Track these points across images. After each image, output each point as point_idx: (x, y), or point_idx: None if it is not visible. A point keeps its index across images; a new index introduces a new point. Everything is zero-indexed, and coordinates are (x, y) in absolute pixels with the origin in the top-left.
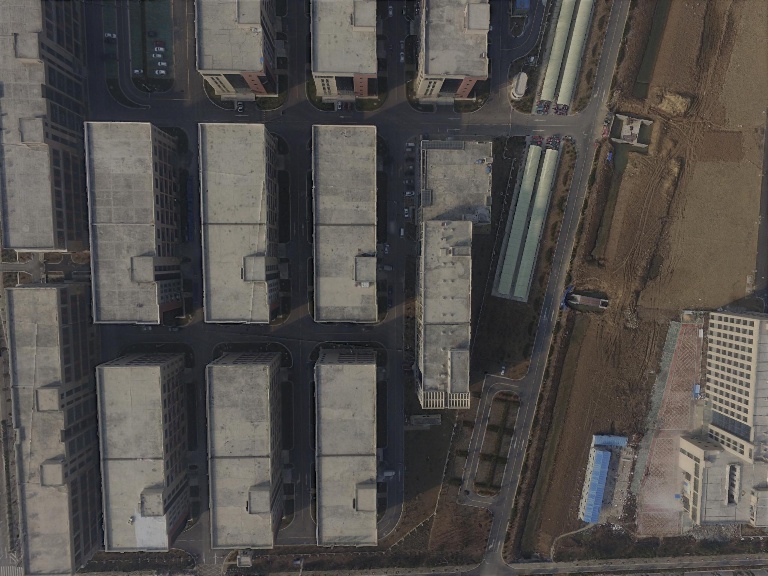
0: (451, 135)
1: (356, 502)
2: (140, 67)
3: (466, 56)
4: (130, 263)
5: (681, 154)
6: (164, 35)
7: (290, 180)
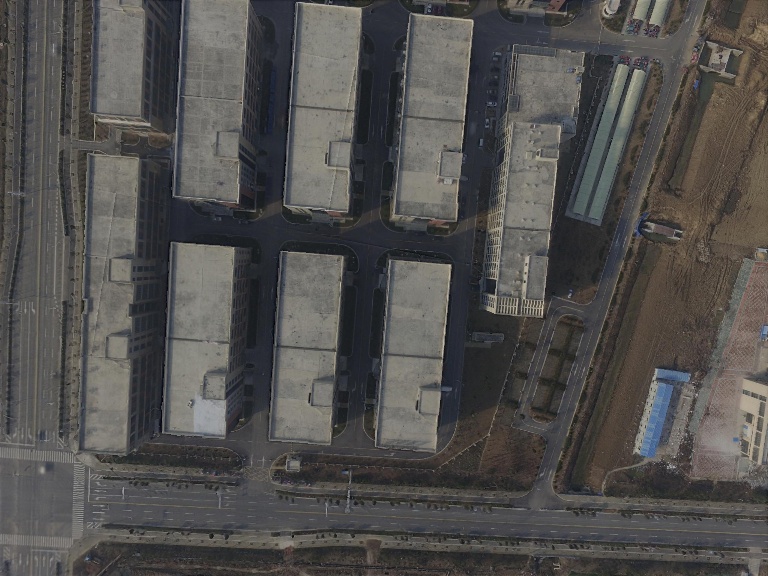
0: None
1: (419, 404)
2: None
3: None
4: (216, 137)
5: None
6: None
7: (373, 81)
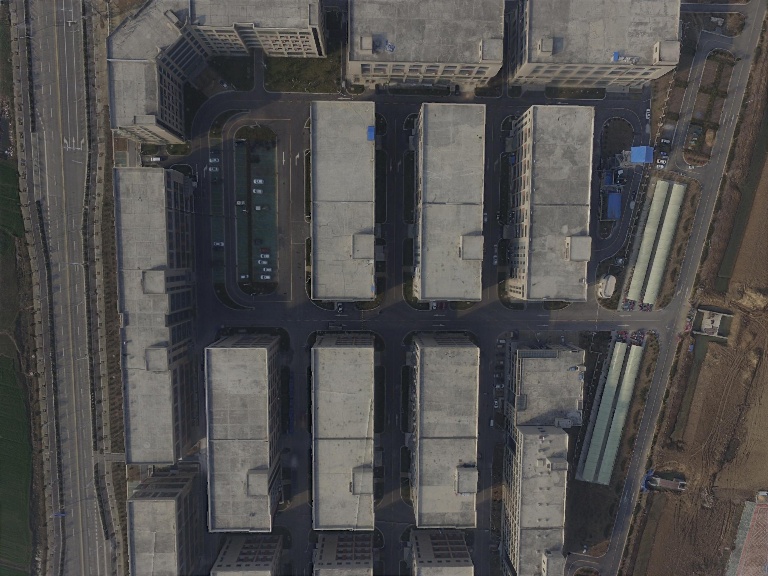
0: (540, 331)
1: None
2: (246, 272)
3: (566, 281)
4: (246, 479)
5: (760, 345)
6: (269, 242)
7: (385, 374)
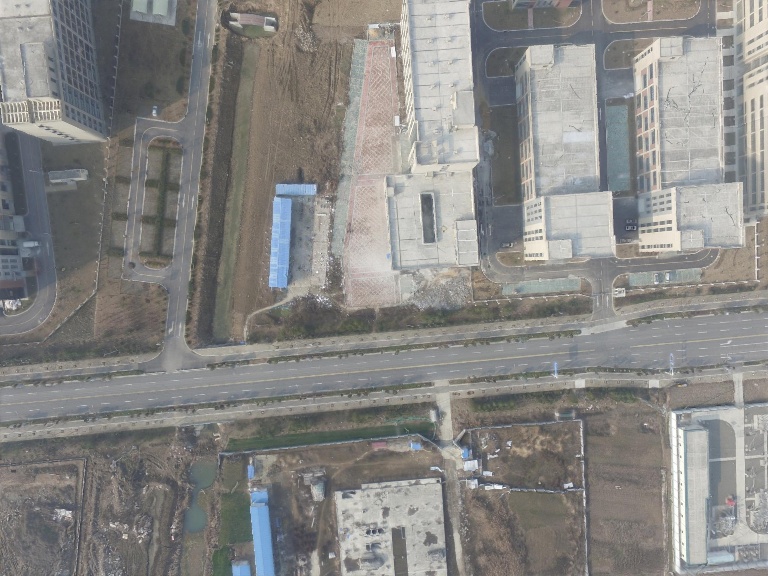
0: None
1: None
2: None
3: None
4: None
5: None
6: None
7: None
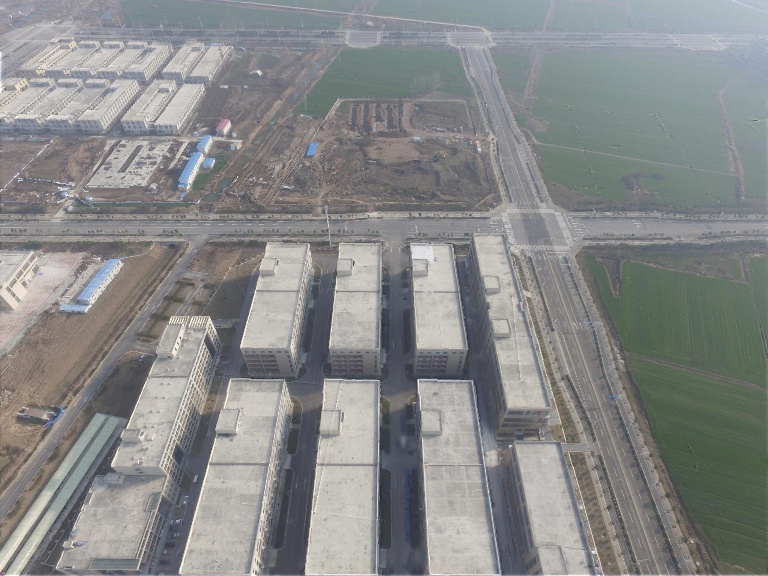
0: None
1: (276, 263)
2: None
3: None
4: None
5: None
6: None
7: (303, 538)
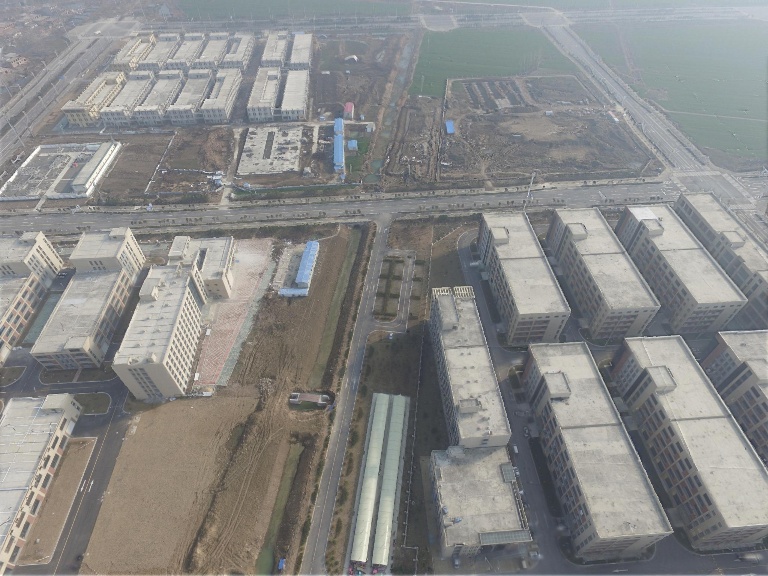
0: (487, 574)
1: (507, 232)
2: None
3: None
4: None
5: None
6: None
7: None
